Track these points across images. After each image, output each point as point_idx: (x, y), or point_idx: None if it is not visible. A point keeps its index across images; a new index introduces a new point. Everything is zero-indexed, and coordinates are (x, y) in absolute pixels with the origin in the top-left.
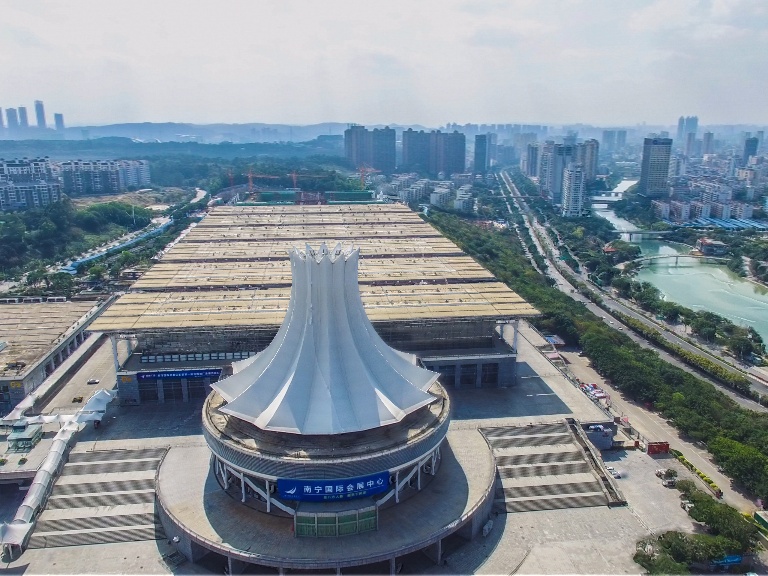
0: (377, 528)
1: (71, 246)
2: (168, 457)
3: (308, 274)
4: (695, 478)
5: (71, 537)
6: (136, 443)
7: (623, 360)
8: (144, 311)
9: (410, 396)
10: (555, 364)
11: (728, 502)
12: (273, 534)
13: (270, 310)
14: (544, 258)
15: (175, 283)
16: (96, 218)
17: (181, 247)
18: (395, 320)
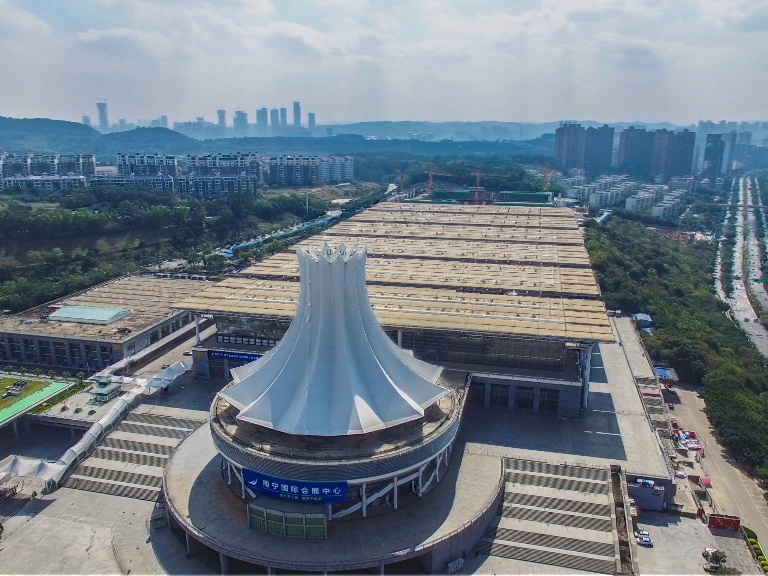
0: (325, 537)
1: (244, 232)
2: (199, 430)
3: (307, 272)
4: (755, 569)
5: (96, 484)
6: (183, 413)
7: (738, 409)
8: (229, 295)
9: (397, 409)
10: (644, 401)
11: None
12: (232, 520)
13: None
14: (735, 278)
15: (278, 272)
16: (273, 208)
17: (314, 239)
18: (445, 329)
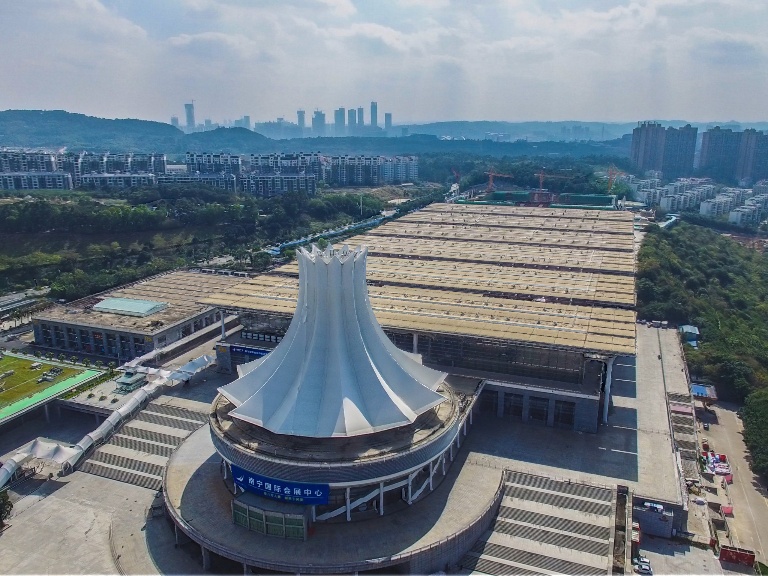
0: (304, 538)
1: (295, 230)
2: None
3: None
4: None
5: (108, 470)
6: (199, 406)
7: None
8: (256, 292)
9: (387, 414)
10: (671, 419)
11: None
12: (219, 514)
13: None
14: None
15: None
16: (326, 207)
17: (356, 239)
18: (459, 334)
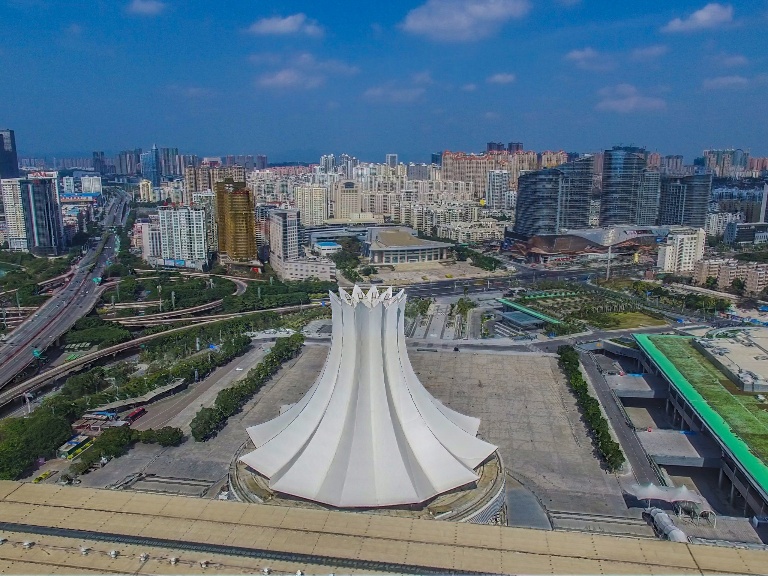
0: None
1: None
2: None
3: None
4: None
5: None
6: None
7: None
8: None
9: None
10: None
11: (59, 468)
12: None
13: (420, 573)
14: None
15: None
16: None
17: None
18: None
